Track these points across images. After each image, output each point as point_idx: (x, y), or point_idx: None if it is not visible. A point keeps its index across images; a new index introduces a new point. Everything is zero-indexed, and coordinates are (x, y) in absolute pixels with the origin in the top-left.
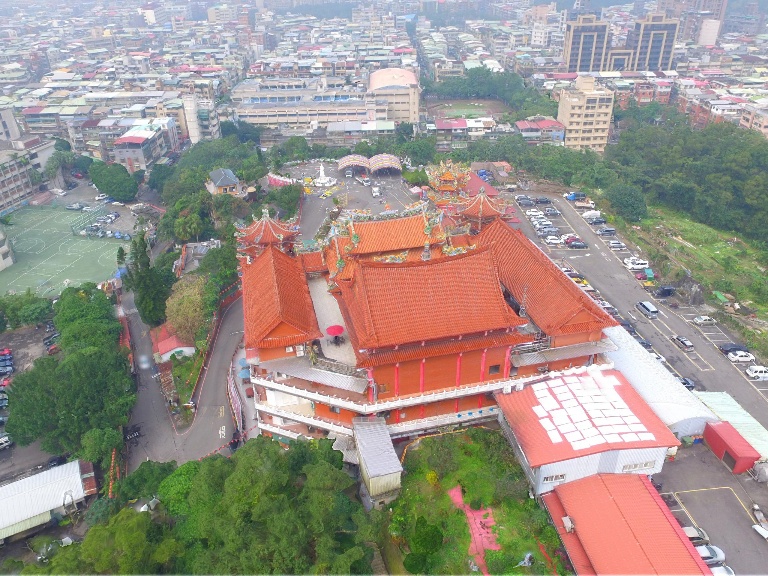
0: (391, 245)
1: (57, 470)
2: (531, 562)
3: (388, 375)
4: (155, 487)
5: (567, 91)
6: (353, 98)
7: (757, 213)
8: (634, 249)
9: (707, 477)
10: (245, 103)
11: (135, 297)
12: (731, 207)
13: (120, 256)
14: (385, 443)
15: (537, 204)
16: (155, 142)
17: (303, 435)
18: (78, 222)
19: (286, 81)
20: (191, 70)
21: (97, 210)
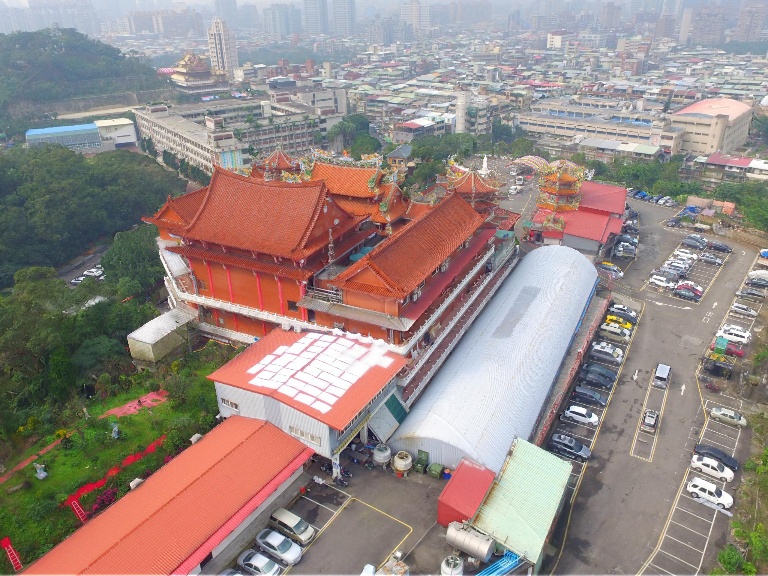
0: (334, 189)
1: None
2: (118, 436)
3: (204, 272)
4: None
5: None
6: None
7: None
8: (765, 323)
9: (406, 507)
10: (542, 114)
11: None
12: None
13: None
14: (173, 325)
15: (707, 249)
16: (433, 132)
17: None
18: None
19: (604, 101)
20: (533, 84)
21: None
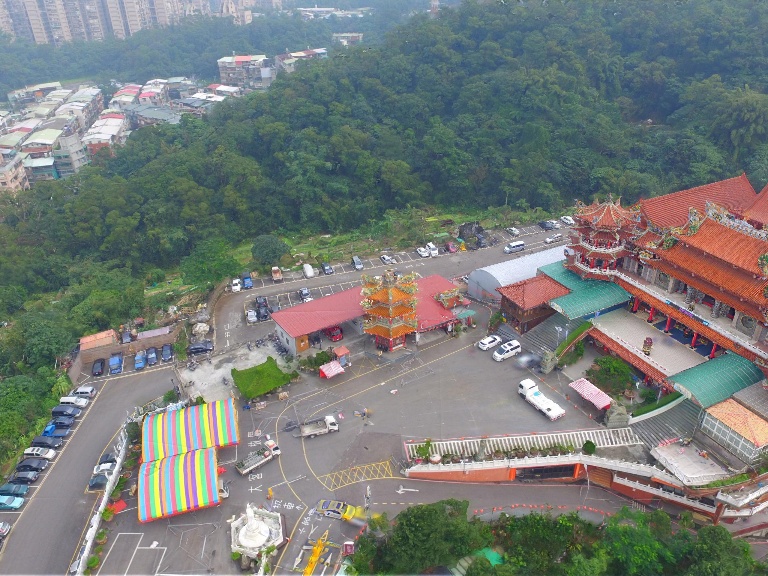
0: None
1: None
2: None
3: None
4: None
5: None
6: None
7: (242, 216)
8: (389, 253)
9: None
10: None
11: None
12: (229, 224)
13: None
14: None
15: None
16: None
17: None
18: None
19: None
20: None
21: None
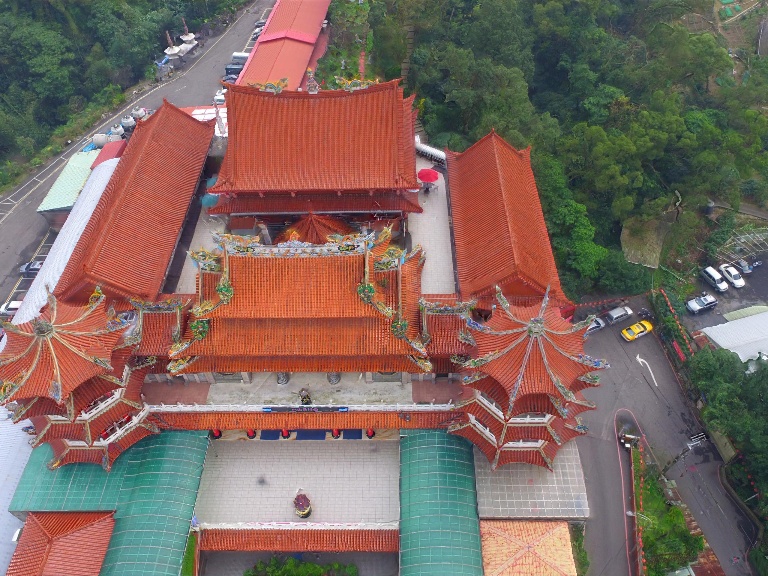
0: None
1: None
2: None
3: None
4: (612, 251)
5: None
6: None
7: None
8: None
9: None
10: None
11: None
12: None
13: None
14: None
15: None
16: None
17: None
18: None
19: None
20: None
21: None
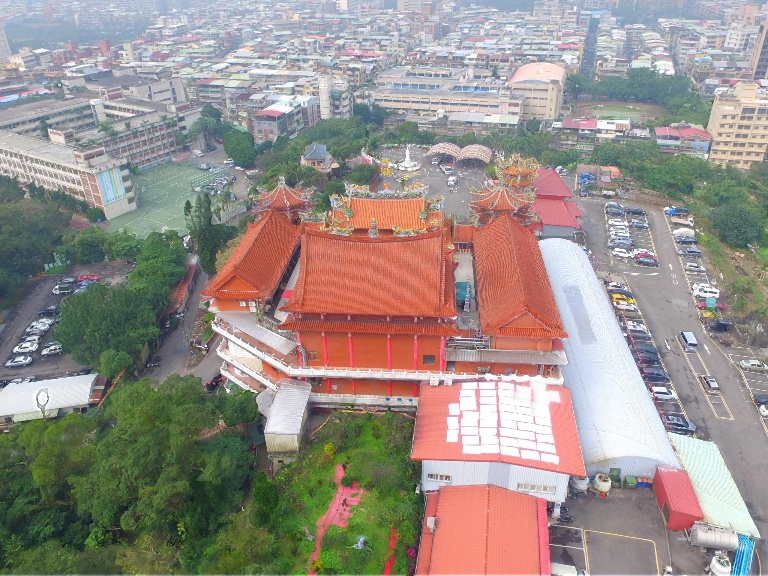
0: (382, 224)
1: (79, 378)
2: None
3: (317, 343)
4: None
5: (722, 98)
6: (493, 90)
7: None
8: (714, 276)
9: (633, 524)
10: (387, 88)
11: (198, 247)
12: None
13: (187, 208)
14: (298, 407)
15: (627, 214)
16: (292, 117)
17: (249, 387)
18: (198, 180)
19: (435, 70)
20: (354, 54)
21: (218, 171)
